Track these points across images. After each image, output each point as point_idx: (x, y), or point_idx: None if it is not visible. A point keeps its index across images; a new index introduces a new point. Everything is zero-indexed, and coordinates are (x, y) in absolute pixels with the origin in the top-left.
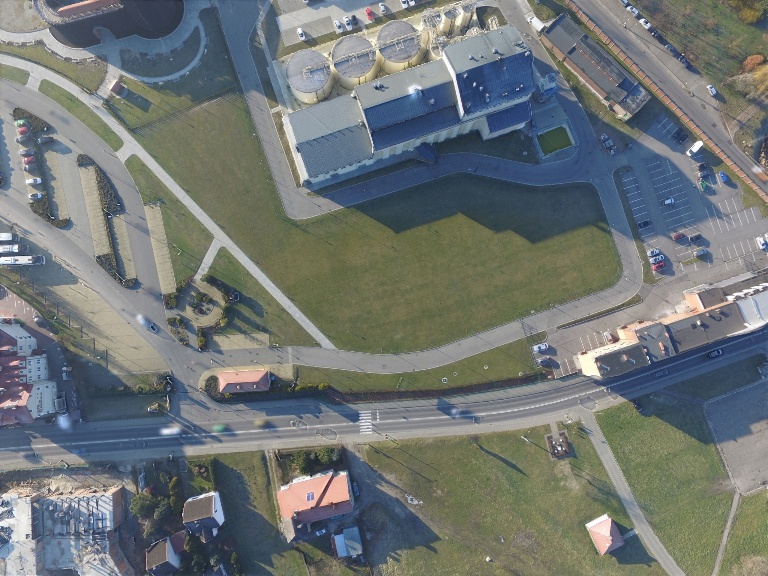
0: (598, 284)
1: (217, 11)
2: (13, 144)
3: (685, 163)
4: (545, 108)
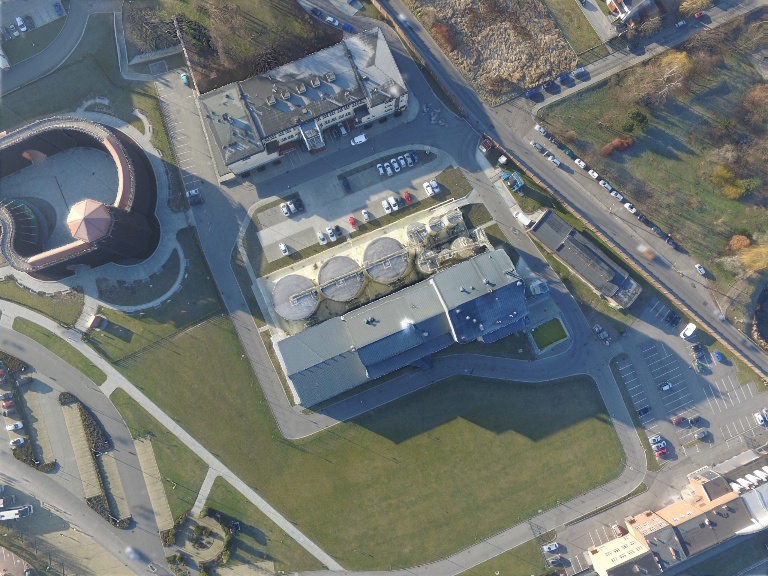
0: (603, 476)
1: (195, 230)
2: None
3: (680, 345)
4: (537, 302)
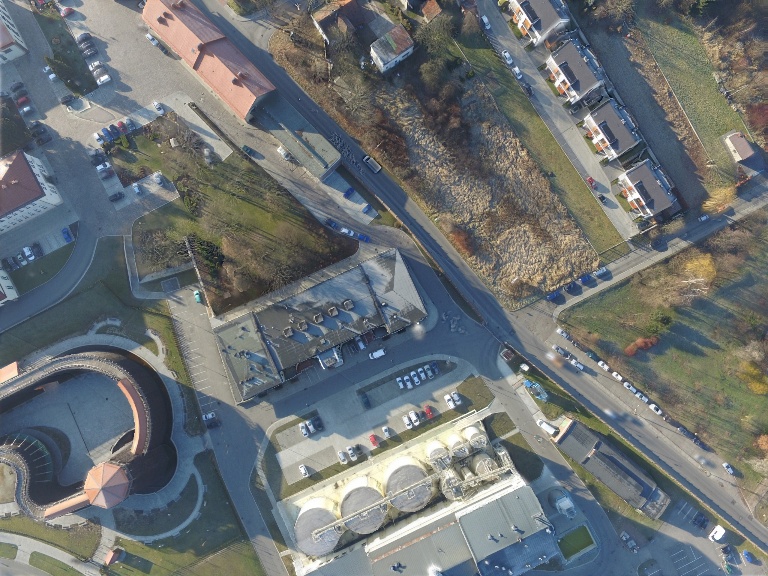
0: None
1: (212, 454)
2: None
3: (708, 547)
4: None
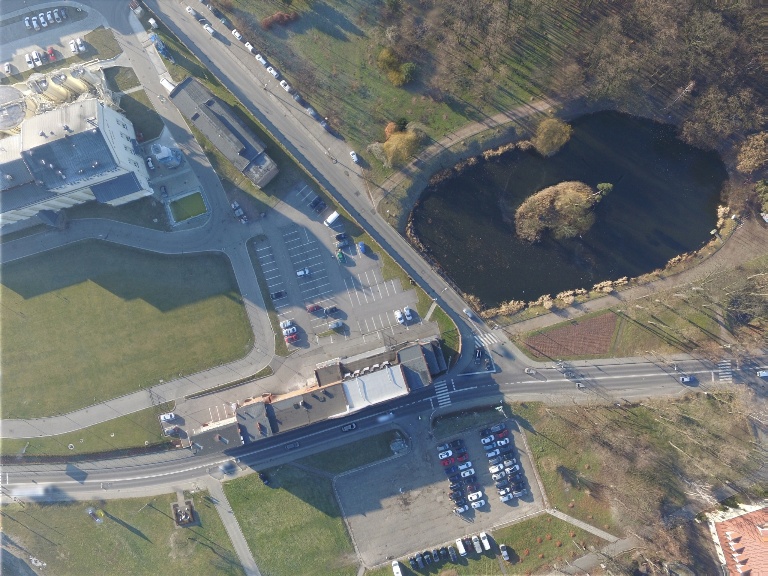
0: (228, 355)
1: None
2: None
3: (324, 233)
4: (178, 174)
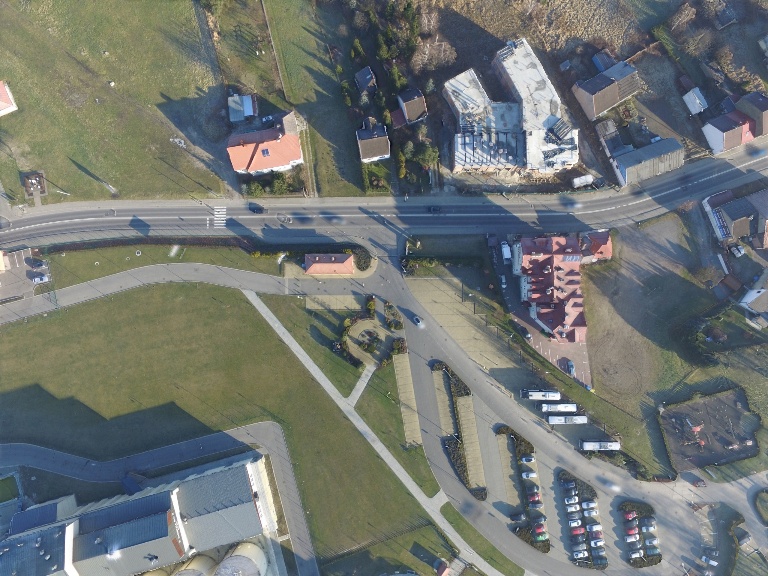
0: None
1: None
2: (551, 515)
3: None
4: (7, 526)
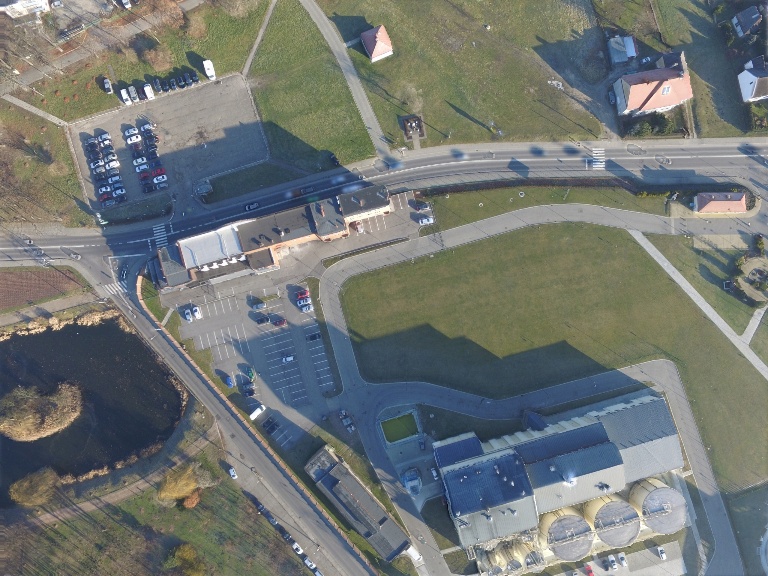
0: (365, 280)
1: None
2: None
3: (267, 398)
4: (408, 462)
